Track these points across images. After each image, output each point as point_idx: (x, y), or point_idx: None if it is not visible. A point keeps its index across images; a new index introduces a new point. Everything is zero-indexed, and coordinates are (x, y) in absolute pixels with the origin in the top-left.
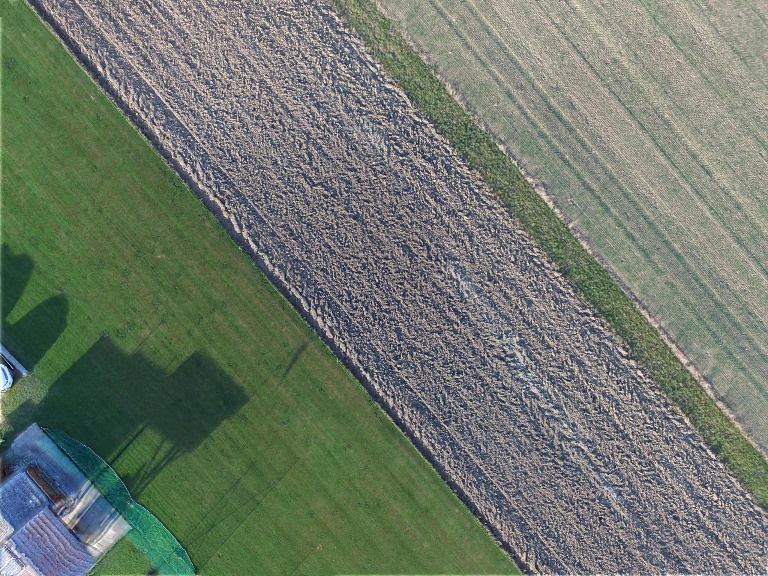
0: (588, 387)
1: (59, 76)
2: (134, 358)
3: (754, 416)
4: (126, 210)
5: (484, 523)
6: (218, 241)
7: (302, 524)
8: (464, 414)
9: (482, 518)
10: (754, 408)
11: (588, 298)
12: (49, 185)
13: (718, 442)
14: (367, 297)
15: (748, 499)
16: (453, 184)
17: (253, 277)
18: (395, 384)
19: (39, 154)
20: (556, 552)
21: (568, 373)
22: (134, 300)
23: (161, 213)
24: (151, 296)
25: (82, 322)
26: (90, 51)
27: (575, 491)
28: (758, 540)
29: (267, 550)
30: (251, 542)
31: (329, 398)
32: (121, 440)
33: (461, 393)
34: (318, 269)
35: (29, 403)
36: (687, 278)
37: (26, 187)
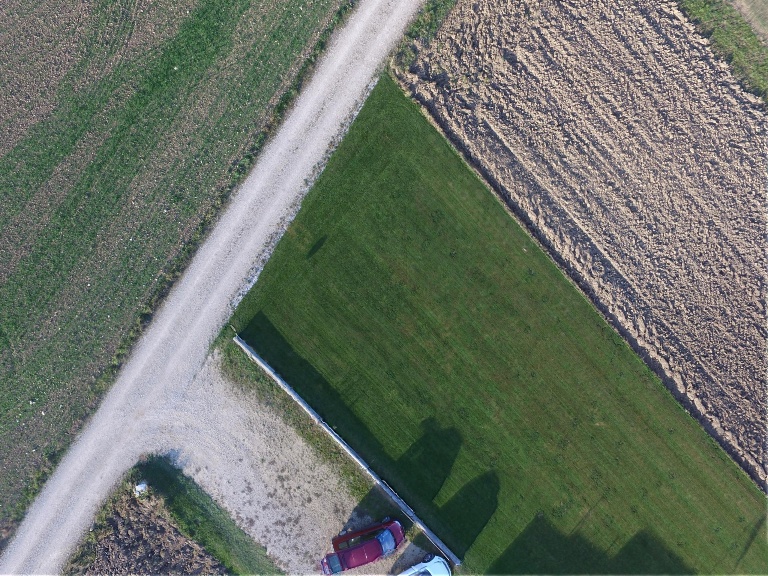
0: None
1: (488, 228)
2: (572, 540)
3: None
4: (562, 374)
5: None
6: (662, 404)
7: None
8: None
9: None
10: None
11: None
12: (478, 350)
13: None
14: None
15: None
16: None
17: (703, 444)
18: None
19: (469, 316)
20: None
21: None
22: (570, 474)
23: (600, 375)
24: (589, 469)
25: (514, 501)
26: (523, 199)
27: None
28: None
29: None
30: None
31: None
32: None
33: None
34: None
35: None
36: None
37: (453, 353)
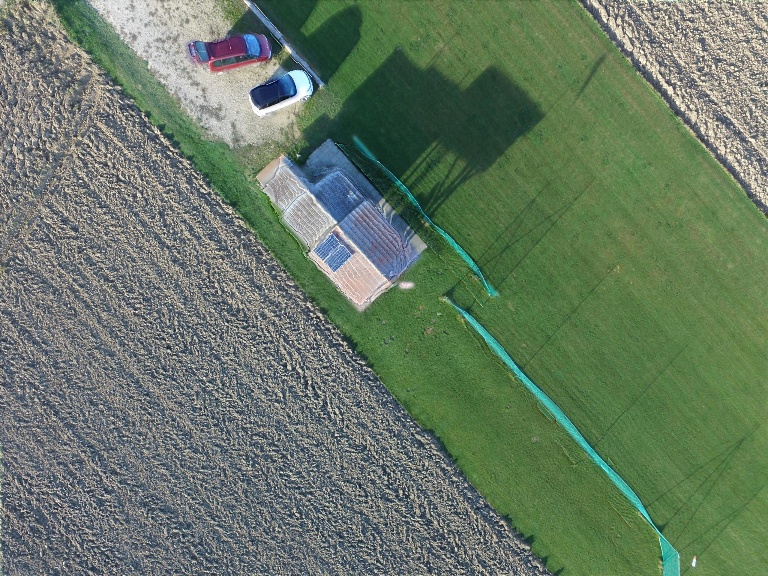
0: None
1: None
2: (427, 72)
3: None
4: None
5: None
6: None
7: (599, 245)
8: None
9: None
10: None
11: None
12: None
13: None
14: (669, 5)
15: None
16: None
17: None
18: (699, 97)
19: None
20: None
21: None
22: (427, 11)
23: None
24: None
25: (375, 34)
26: None
27: None
28: None
29: (562, 272)
30: (546, 263)
31: (629, 112)
32: (414, 157)
33: None
34: None
35: (324, 117)
36: None
37: None
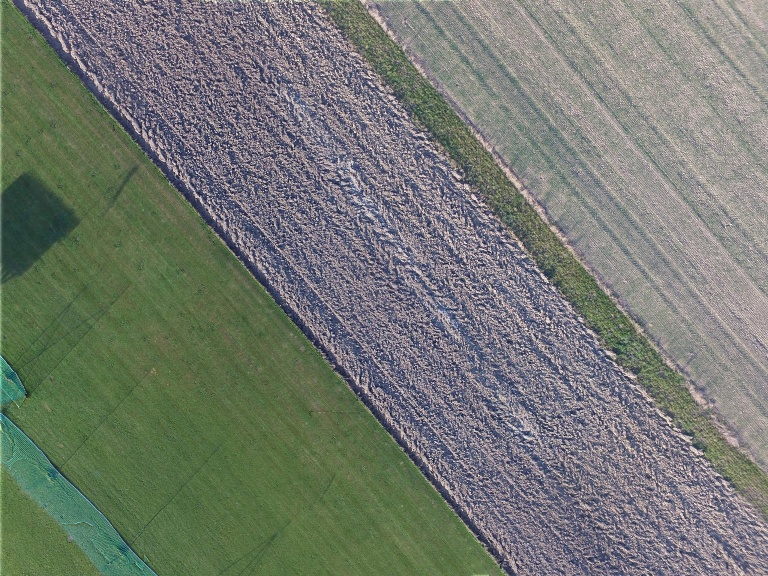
0: (423, 211)
1: None
2: None
3: (585, 238)
4: None
5: (318, 347)
6: (45, 60)
7: (135, 348)
8: (298, 238)
9: (316, 341)
10: (585, 230)
11: (423, 122)
12: None
13: (552, 266)
14: (200, 120)
15: (581, 322)
16: (285, 5)
17: (82, 97)
18: (228, 208)
19: None
20: (390, 375)
21: (403, 197)
22: None
23: None
24: None
25: None
26: None
27: (409, 315)
28: (590, 363)
29: (100, 374)
30: (83, 366)
31: (161, 221)
32: None
33: (295, 217)
34: (149, 91)
35: None
36: (521, 102)
37: None
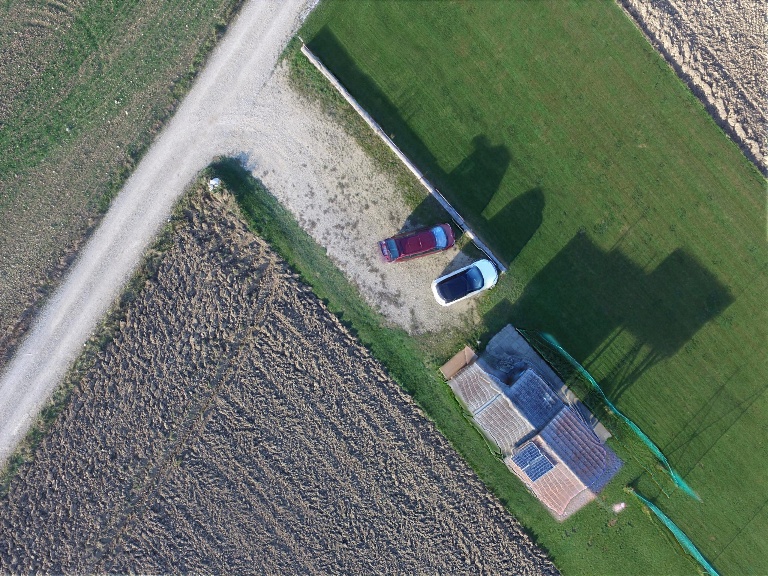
0: None
1: None
2: (612, 256)
3: None
4: (608, 96)
5: None
6: (703, 128)
7: None
8: None
9: None
10: None
11: None
12: (528, 71)
13: None
14: None
15: None
16: None
17: (742, 167)
18: None
19: (521, 37)
20: None
21: None
22: (612, 193)
23: (645, 99)
24: (631, 189)
25: (558, 217)
26: None
27: None
28: None
29: (752, 462)
30: (736, 453)
31: None
32: (598, 343)
33: None
34: None
35: (505, 303)
36: None
37: (504, 73)
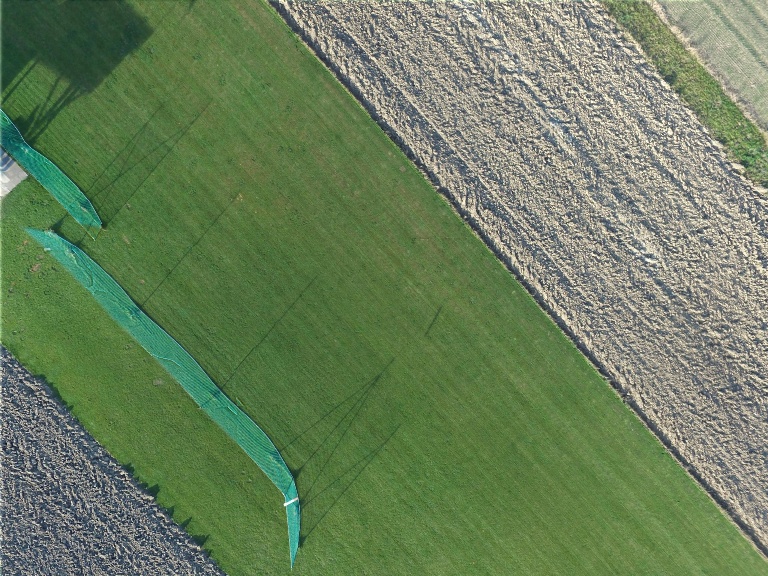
0: (530, 13)
1: None
2: None
3: (711, 36)
4: None
5: (420, 166)
6: None
7: (219, 172)
8: (394, 46)
9: (417, 160)
10: (711, 27)
11: None
12: None
13: (673, 72)
14: None
15: (706, 134)
16: None
17: None
18: (317, 13)
19: None
20: (499, 195)
21: None
22: None
23: None
24: None
25: None
26: None
27: (518, 129)
28: (716, 178)
29: (181, 202)
30: (163, 192)
31: (243, 29)
32: (10, 78)
33: (390, 23)
34: None
35: None
36: None
37: None
